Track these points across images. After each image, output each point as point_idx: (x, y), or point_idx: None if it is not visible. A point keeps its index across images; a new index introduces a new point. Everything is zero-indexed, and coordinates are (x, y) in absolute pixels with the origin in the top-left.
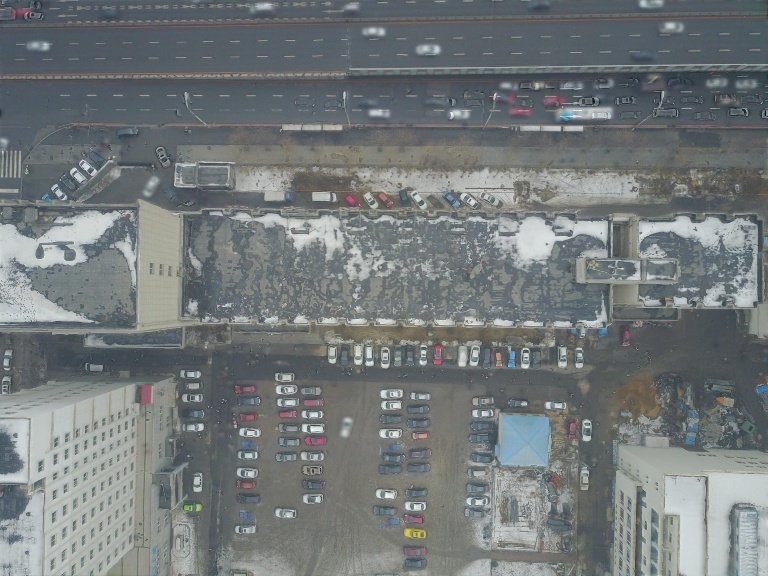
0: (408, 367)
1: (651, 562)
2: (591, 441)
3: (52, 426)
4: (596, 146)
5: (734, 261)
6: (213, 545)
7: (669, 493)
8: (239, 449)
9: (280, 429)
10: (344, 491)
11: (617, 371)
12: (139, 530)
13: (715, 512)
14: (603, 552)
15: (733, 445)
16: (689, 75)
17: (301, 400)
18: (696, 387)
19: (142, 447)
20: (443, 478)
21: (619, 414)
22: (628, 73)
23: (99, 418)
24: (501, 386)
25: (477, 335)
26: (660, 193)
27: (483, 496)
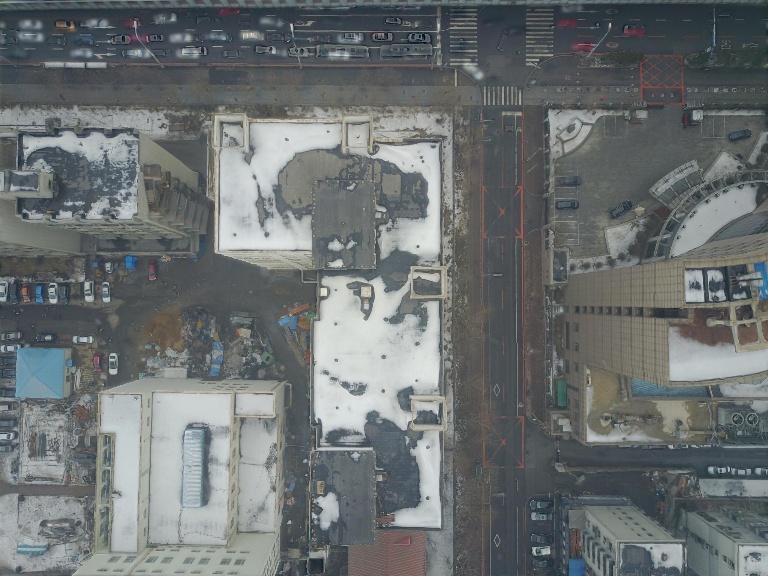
0: None
1: None
2: (118, 374)
3: None
4: (112, 81)
5: (118, 175)
6: None
7: (106, 412)
8: None
9: None
10: None
11: (145, 305)
12: None
13: (169, 432)
14: None
15: (251, 375)
16: (218, 14)
17: None
18: (222, 320)
19: None
20: None
21: None
22: (155, 11)
23: None
24: (32, 322)
25: (8, 271)
26: (189, 129)
27: (10, 431)
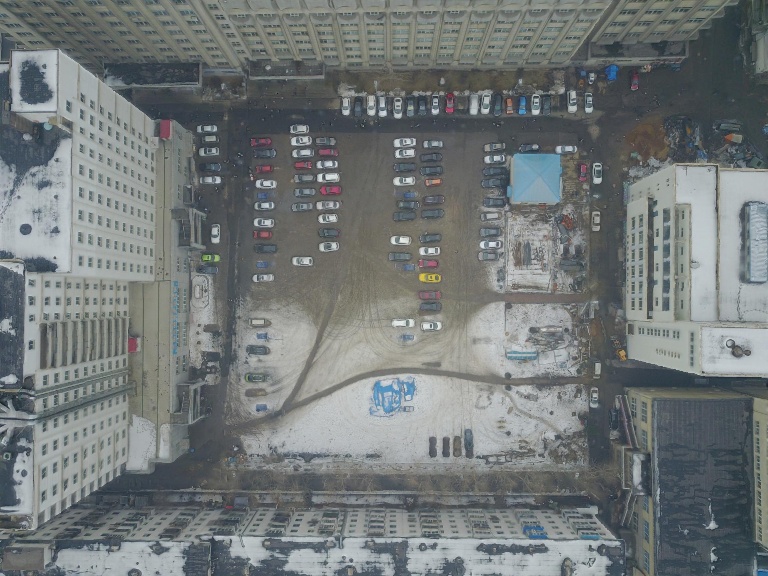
0: (420, 117)
1: (663, 261)
2: (602, 184)
3: (78, 77)
4: None
5: None
6: (231, 295)
7: (680, 183)
8: (255, 201)
9: (295, 179)
10: (359, 239)
11: (626, 115)
12: (159, 265)
13: (726, 211)
14: (615, 292)
15: None
16: None
17: (316, 151)
18: (704, 129)
19: (161, 185)
20: (456, 224)
21: (629, 157)
22: None
23: (121, 118)
24: (512, 134)
25: (488, 84)
26: None
27: (496, 240)
